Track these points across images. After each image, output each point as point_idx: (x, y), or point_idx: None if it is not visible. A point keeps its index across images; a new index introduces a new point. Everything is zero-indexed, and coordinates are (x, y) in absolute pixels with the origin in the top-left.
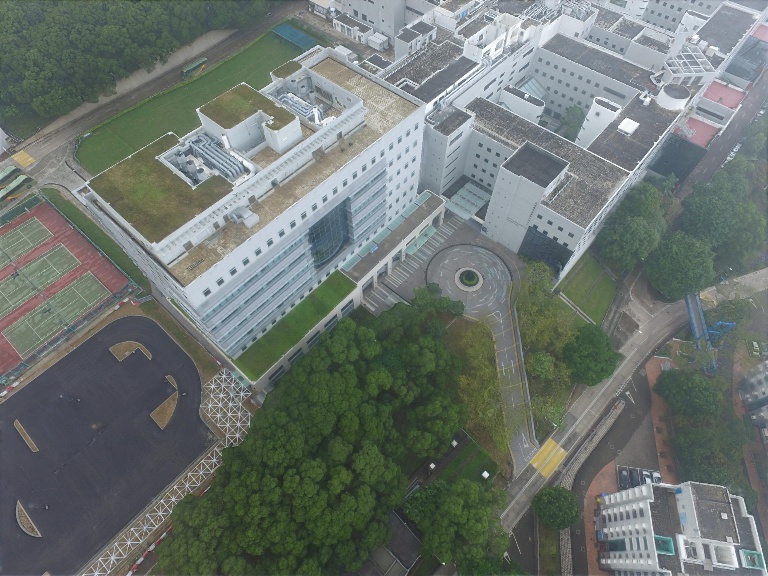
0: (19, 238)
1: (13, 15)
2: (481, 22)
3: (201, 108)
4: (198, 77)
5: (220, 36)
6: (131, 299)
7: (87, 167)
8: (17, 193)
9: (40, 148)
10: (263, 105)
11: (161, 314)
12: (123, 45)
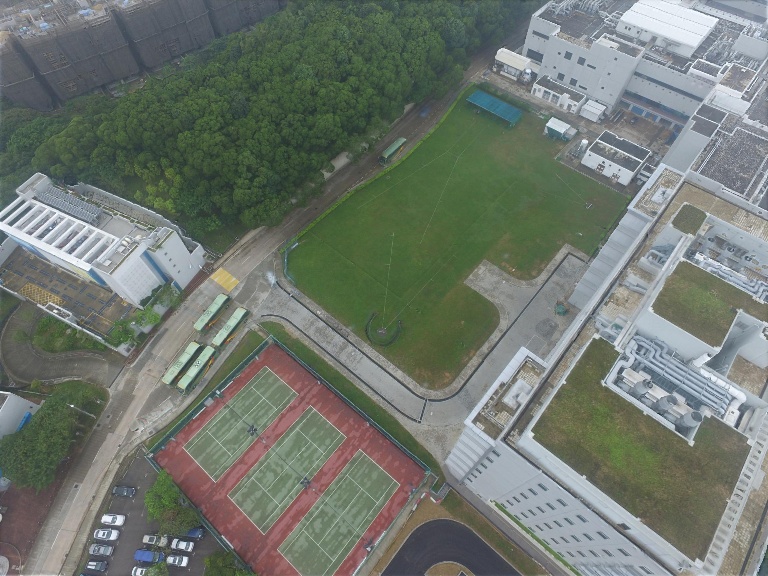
0: (257, 399)
1: (217, 109)
2: (765, 100)
3: (654, 307)
4: (399, 162)
5: (406, 107)
6: (429, 494)
7: (305, 290)
8: (235, 332)
9: (241, 264)
10: (737, 299)
11: (470, 514)
12: (335, 136)
